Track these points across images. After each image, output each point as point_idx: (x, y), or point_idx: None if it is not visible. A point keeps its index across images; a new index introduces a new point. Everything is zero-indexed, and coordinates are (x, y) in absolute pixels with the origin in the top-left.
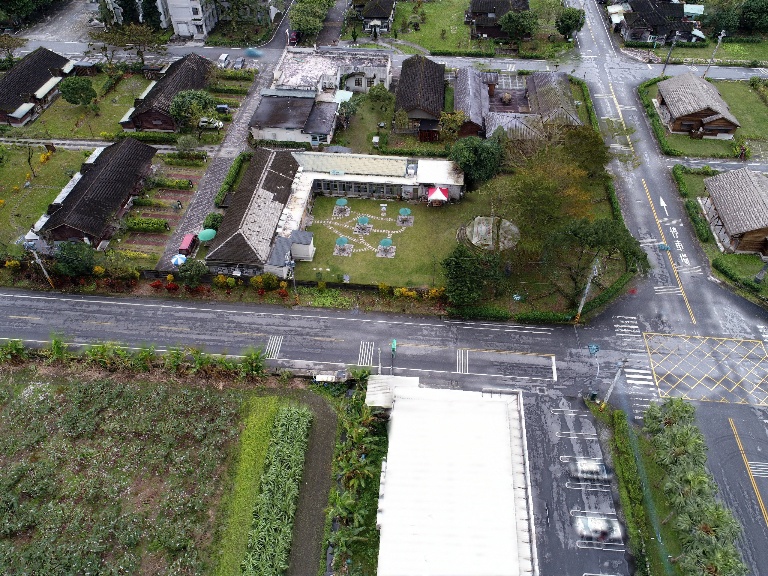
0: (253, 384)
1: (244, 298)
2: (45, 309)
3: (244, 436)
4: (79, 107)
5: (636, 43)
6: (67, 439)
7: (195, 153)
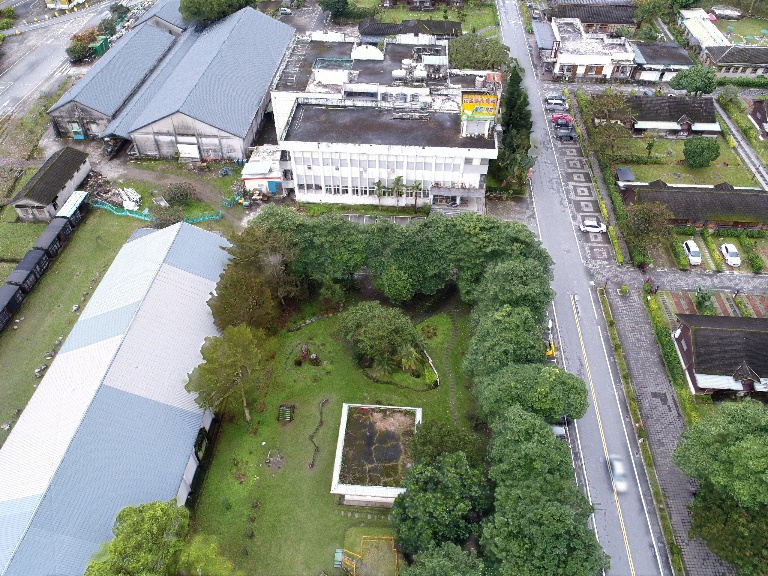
0: None
1: None
2: None
3: None
4: (692, 173)
5: None
6: None
7: None
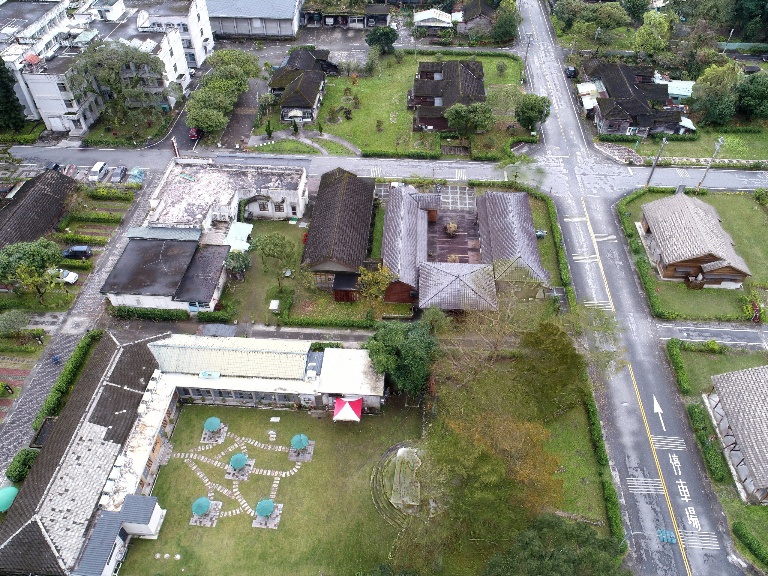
0: None
1: None
2: None
3: None
4: None
5: (613, 137)
6: None
7: (27, 331)
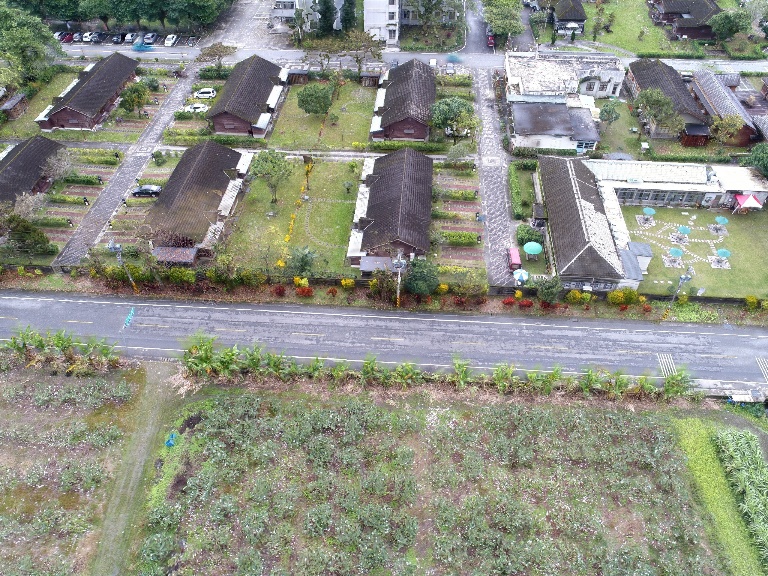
0: (665, 406)
1: (601, 314)
2: (404, 330)
3: (691, 462)
4: (310, 116)
5: None
6: (504, 469)
7: (462, 162)
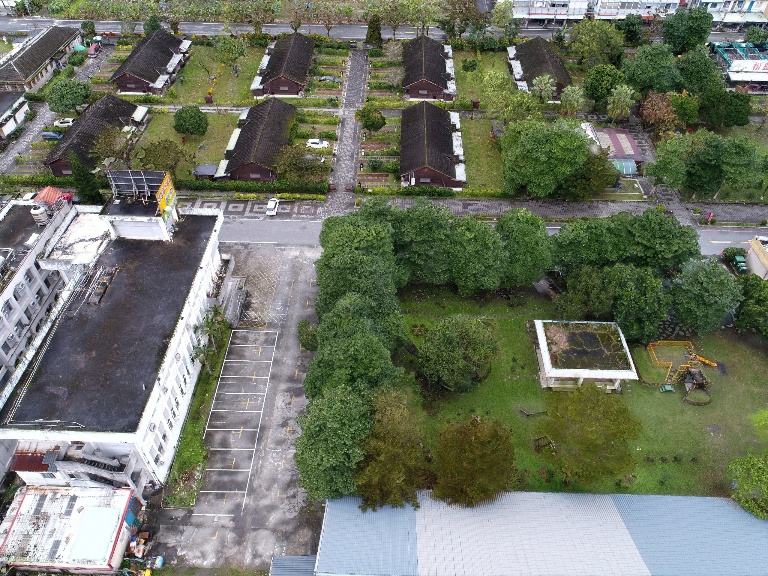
0: None
1: None
2: None
3: None
4: (201, 140)
5: None
6: None
7: None
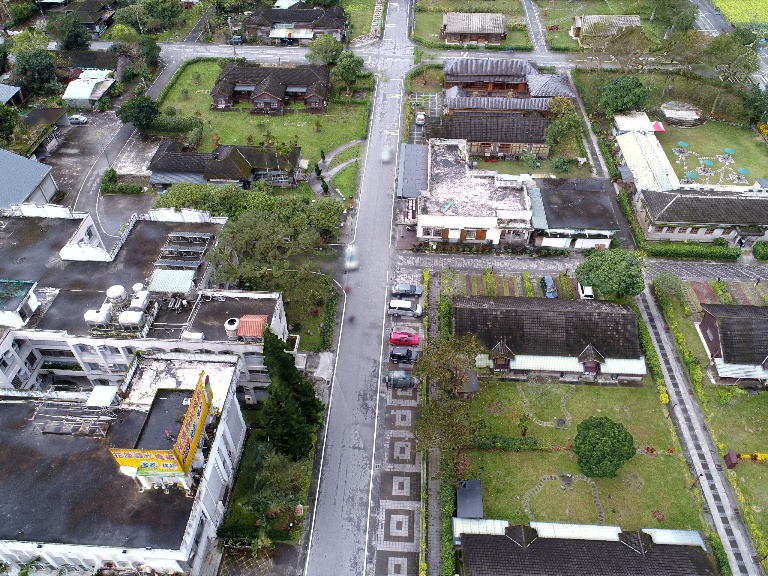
0: None
1: None
2: None
3: None
4: None
5: None
6: None
7: (660, 289)
